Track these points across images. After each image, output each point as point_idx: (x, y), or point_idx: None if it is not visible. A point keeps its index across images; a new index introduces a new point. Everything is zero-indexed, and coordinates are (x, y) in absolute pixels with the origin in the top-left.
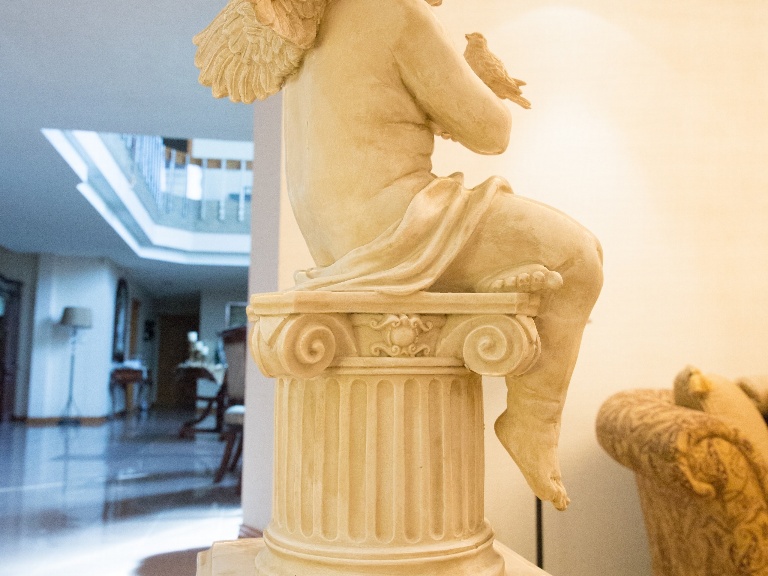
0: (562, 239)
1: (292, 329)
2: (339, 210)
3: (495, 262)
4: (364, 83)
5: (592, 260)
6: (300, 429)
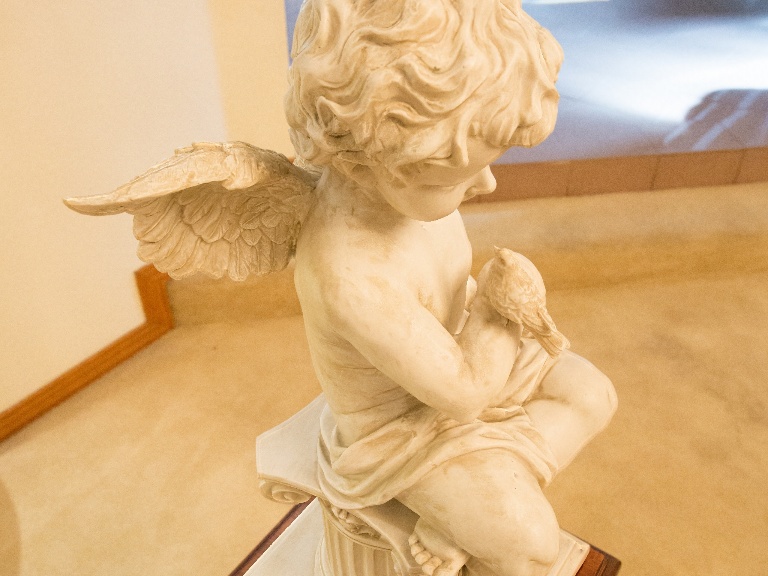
0: (478, 545)
1: (265, 485)
2: None
3: None
4: (314, 334)
5: (510, 572)
6: None
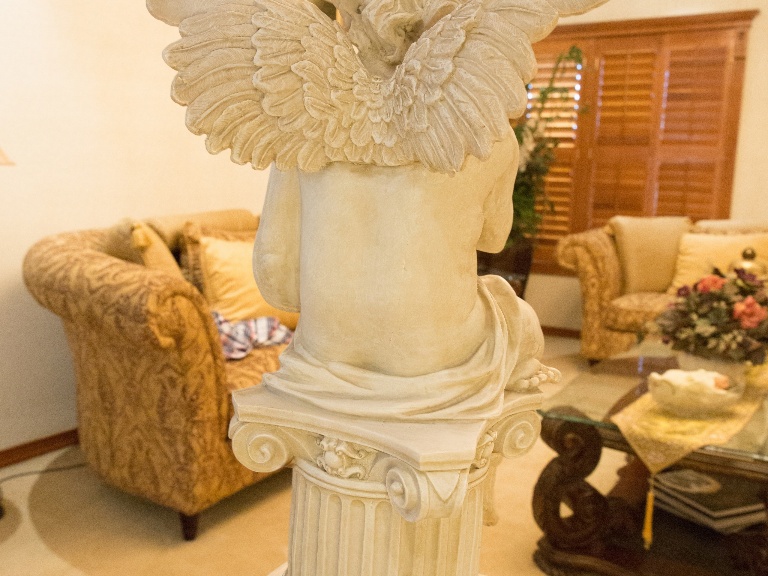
0: None
1: None
2: (433, 334)
3: None
4: (475, 213)
5: None
6: (397, 549)
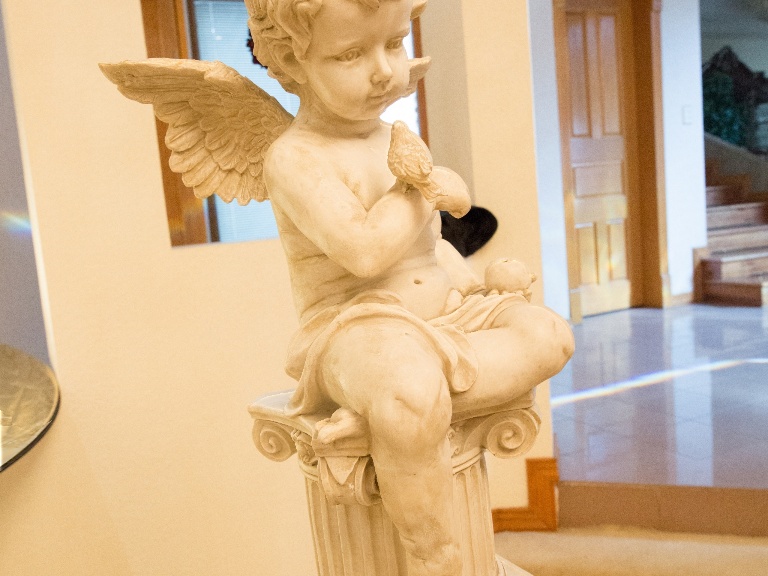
0: (356, 388)
1: (255, 428)
2: None
3: (337, 398)
4: None
5: (379, 414)
6: None
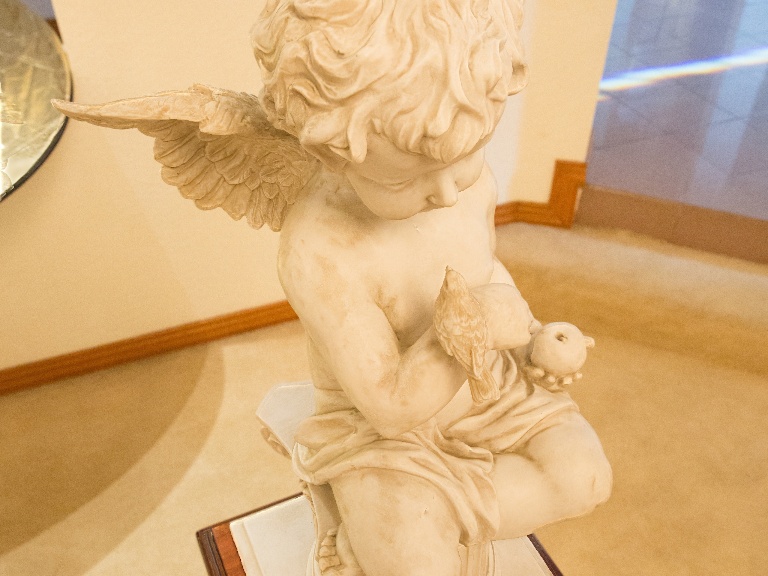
0: (364, 561)
1: (264, 430)
2: None
3: None
4: None
5: None
6: None
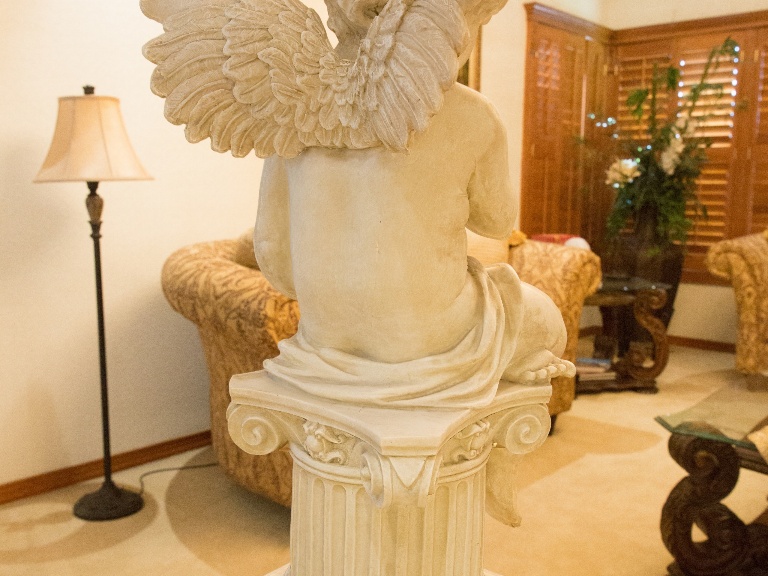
0: None
1: None
2: (413, 320)
3: (520, 352)
4: (452, 195)
5: None
6: (378, 537)
